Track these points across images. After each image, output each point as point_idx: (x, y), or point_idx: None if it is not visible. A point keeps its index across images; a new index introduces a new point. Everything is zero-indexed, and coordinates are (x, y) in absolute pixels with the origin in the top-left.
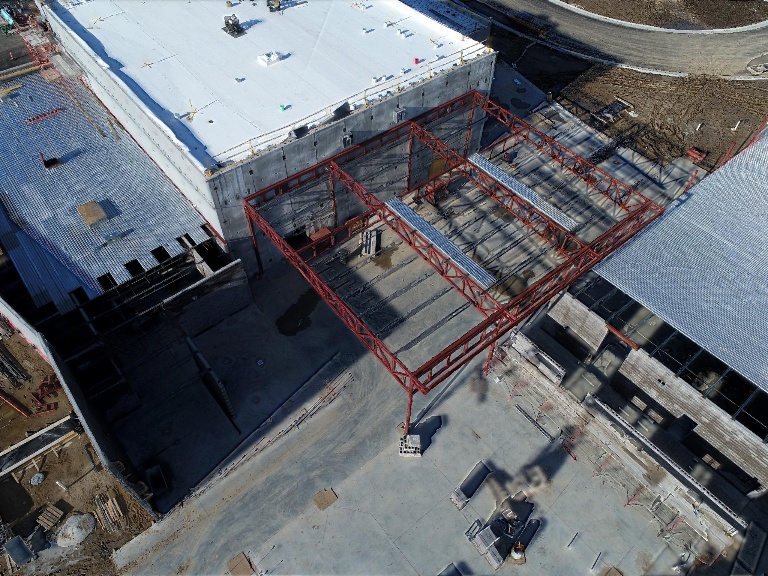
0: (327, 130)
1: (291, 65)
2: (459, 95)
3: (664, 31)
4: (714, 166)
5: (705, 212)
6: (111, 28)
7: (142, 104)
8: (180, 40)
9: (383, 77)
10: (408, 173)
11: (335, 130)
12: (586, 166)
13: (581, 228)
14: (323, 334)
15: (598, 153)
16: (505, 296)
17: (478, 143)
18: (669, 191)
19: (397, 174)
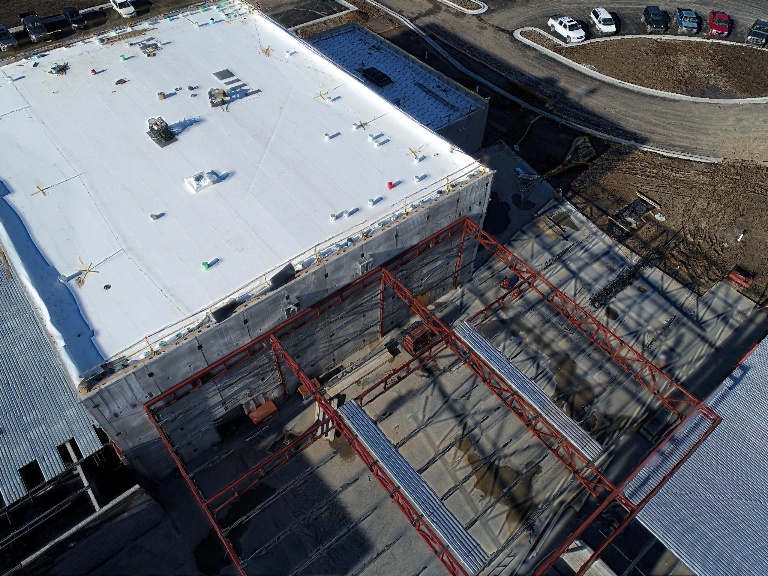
0: (262, 303)
1: (227, 192)
2: (445, 225)
3: (691, 100)
4: (763, 295)
5: (767, 399)
6: (7, 130)
7: (17, 260)
8: (91, 150)
9: (344, 213)
10: (380, 318)
11: (274, 301)
12: (605, 297)
13: (600, 392)
14: (256, 572)
15: (620, 280)
16: (502, 506)
17: (471, 266)
18: (710, 334)
19: (366, 321)
